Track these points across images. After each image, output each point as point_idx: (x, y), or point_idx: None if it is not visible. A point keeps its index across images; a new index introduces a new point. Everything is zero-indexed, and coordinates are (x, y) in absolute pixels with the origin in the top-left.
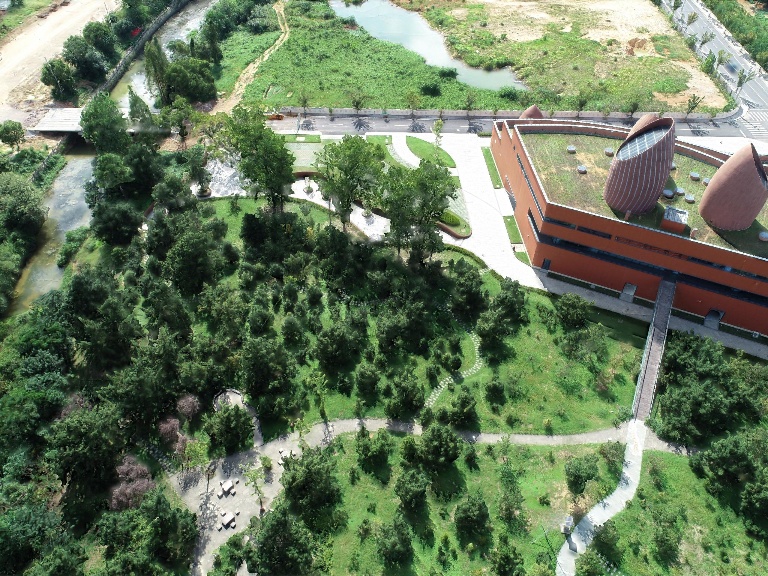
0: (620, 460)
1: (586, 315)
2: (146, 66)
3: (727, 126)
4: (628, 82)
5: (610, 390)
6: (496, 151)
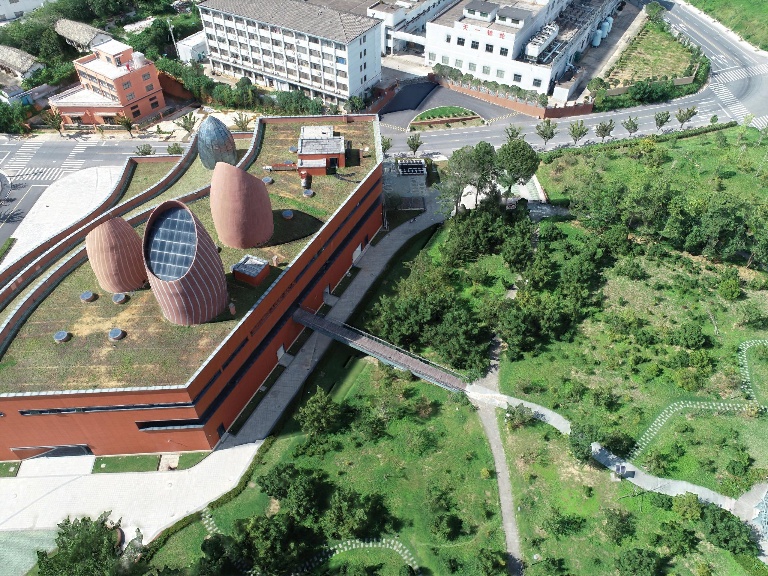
0: None
1: None
2: None
3: (18, 192)
4: None
5: None
6: None
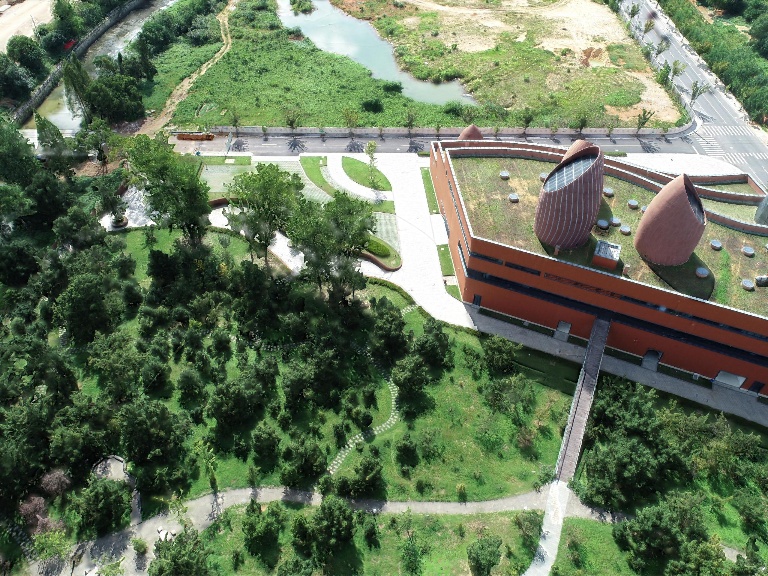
0: (534, 534)
1: (513, 359)
2: (65, 84)
3: (679, 142)
4: (580, 95)
5: (534, 446)
6: (434, 173)
